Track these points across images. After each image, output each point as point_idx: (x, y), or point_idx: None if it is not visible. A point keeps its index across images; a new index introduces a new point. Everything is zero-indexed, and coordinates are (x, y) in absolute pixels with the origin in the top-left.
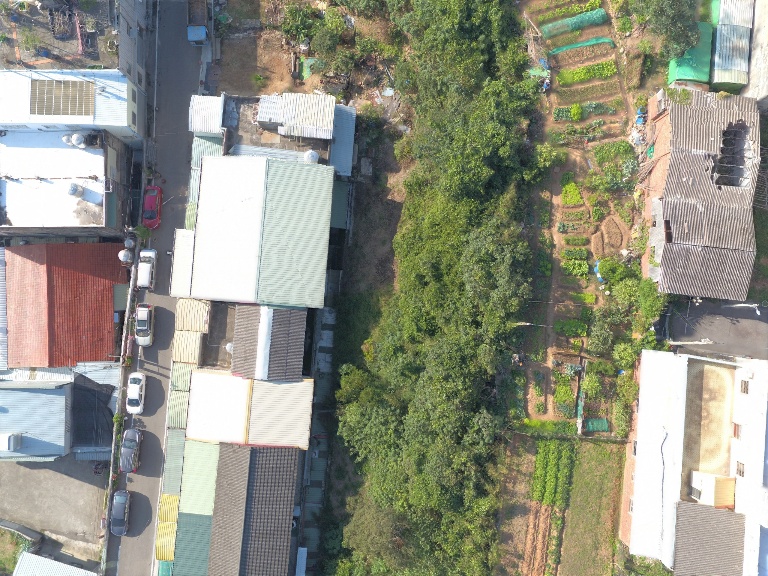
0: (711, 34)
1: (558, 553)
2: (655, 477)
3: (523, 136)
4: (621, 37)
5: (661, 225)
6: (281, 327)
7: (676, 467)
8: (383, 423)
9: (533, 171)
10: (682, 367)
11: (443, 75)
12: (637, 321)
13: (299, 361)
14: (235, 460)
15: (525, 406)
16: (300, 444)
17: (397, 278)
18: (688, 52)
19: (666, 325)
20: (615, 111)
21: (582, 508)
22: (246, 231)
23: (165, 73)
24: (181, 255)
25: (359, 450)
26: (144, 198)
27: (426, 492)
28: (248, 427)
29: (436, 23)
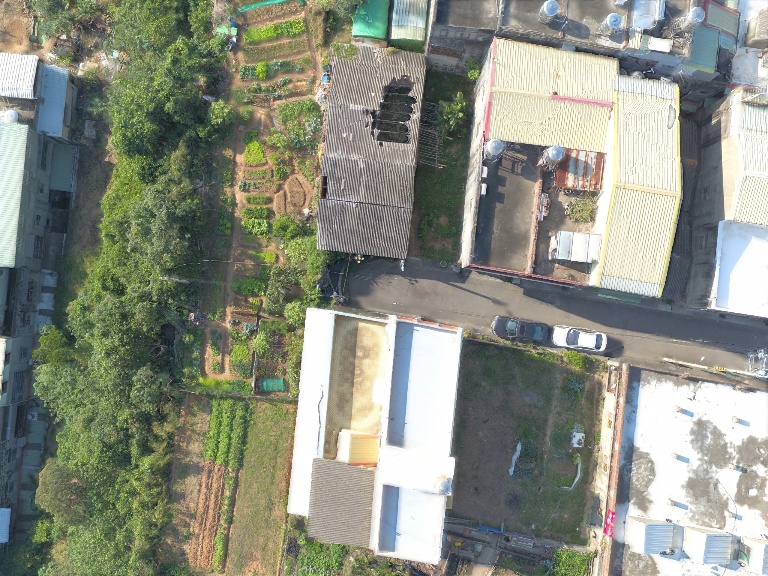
0: None
1: (230, 513)
2: (311, 436)
3: (198, 93)
4: None
5: None
6: None
7: (321, 424)
8: (71, 383)
9: (206, 128)
10: (329, 324)
11: (142, 34)
12: (304, 279)
13: None
14: None
15: (202, 366)
16: None
17: None
18: (364, 8)
19: (339, 284)
20: (302, 69)
21: (256, 468)
22: None
23: None
24: None
25: (57, 411)
26: None
27: (88, 449)
28: None
29: None
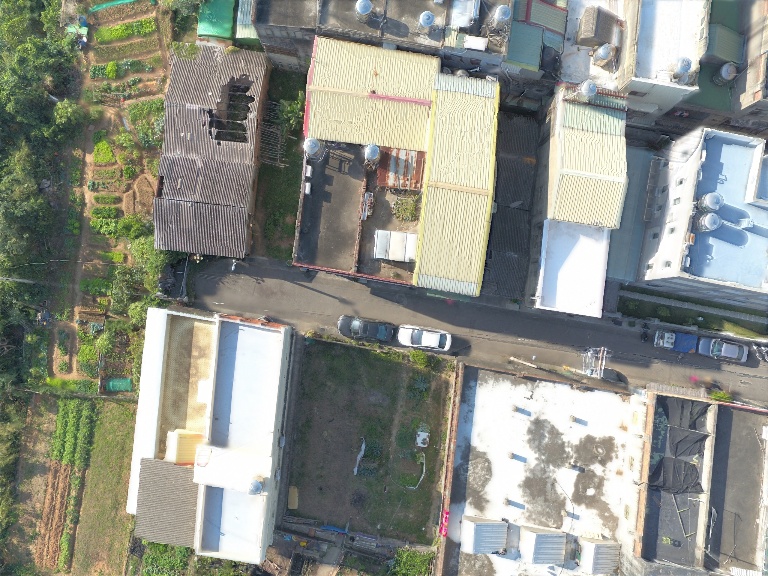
0: None
1: (76, 513)
2: (149, 435)
3: (44, 93)
4: None
5: None
6: None
7: None
8: None
9: (51, 128)
10: (161, 323)
11: None
12: None
13: None
14: None
15: (50, 365)
16: None
17: None
18: (208, 7)
19: (183, 284)
20: (152, 69)
21: (102, 468)
22: None
23: None
24: None
25: None
26: None
27: None
28: None
29: None
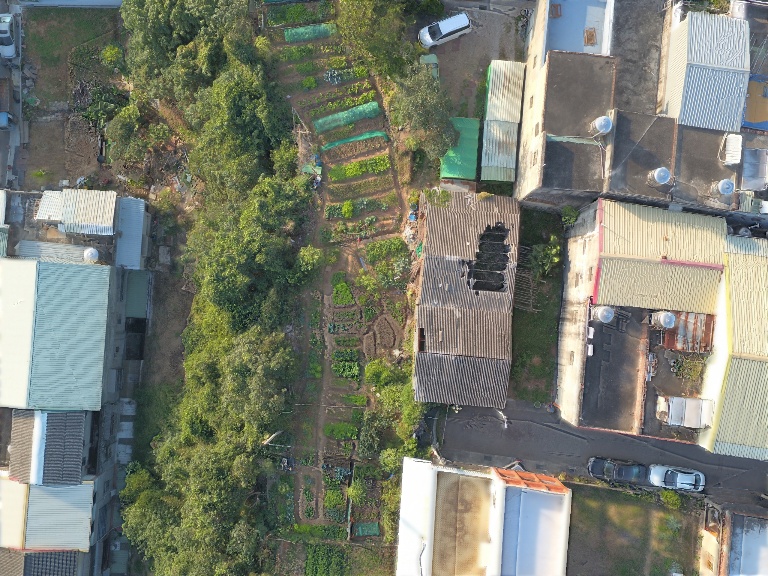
0: (477, 130)
1: None
2: None
3: (287, 238)
4: (394, 131)
5: (417, 332)
6: (56, 431)
7: None
8: (161, 525)
9: (296, 274)
10: (432, 481)
11: (222, 169)
12: (400, 428)
13: (77, 464)
14: (11, 566)
15: (296, 511)
16: (80, 547)
17: (186, 373)
18: (453, 150)
19: (434, 429)
20: (388, 207)
21: None
22: (18, 335)
23: None
24: None
25: (145, 549)
26: None
27: None
28: (25, 532)
29: (215, 116)
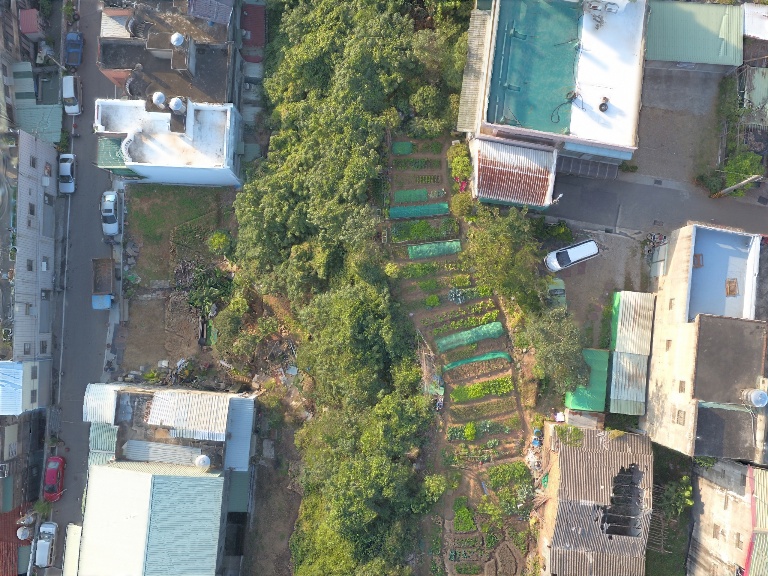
0: (607, 362)
1: None
2: None
3: (411, 466)
4: (518, 352)
5: None
6: None
7: None
8: None
9: (421, 505)
10: None
11: (338, 380)
12: None
13: None
14: None
15: None
16: None
17: None
18: None
19: None
20: (511, 430)
21: None
22: (130, 551)
23: (72, 335)
24: (72, 553)
25: None
26: (45, 470)
27: None
28: None
29: (332, 325)
